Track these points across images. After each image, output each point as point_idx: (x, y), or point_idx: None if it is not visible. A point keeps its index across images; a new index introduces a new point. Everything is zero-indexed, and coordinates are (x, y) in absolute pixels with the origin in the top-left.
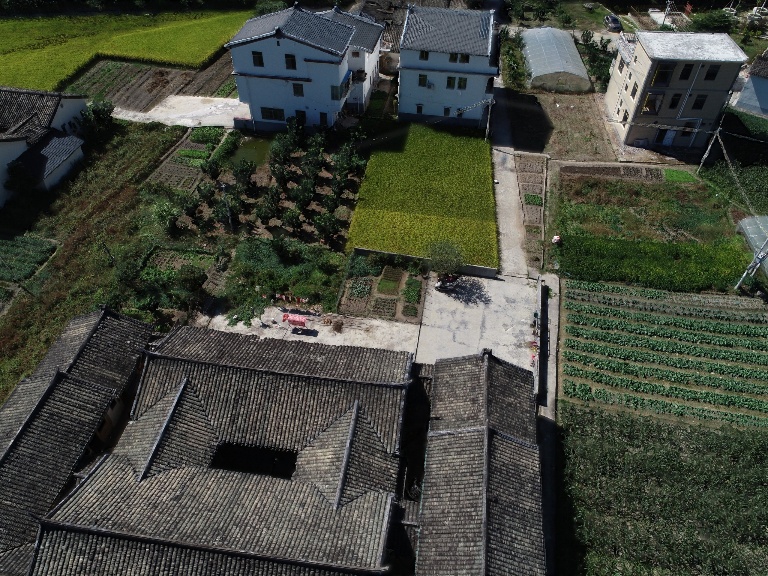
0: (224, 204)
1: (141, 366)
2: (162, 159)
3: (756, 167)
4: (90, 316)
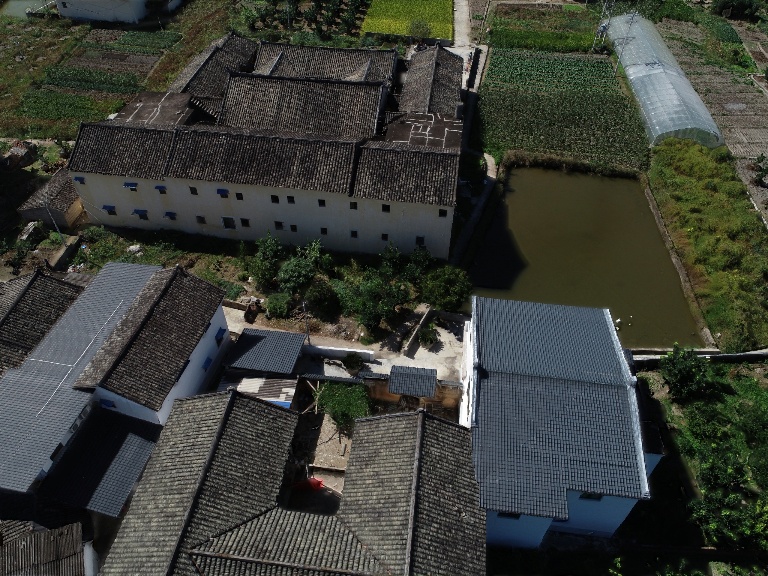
0: (284, 13)
1: (253, 60)
2: (238, 1)
3: (623, 2)
4: (223, 37)
